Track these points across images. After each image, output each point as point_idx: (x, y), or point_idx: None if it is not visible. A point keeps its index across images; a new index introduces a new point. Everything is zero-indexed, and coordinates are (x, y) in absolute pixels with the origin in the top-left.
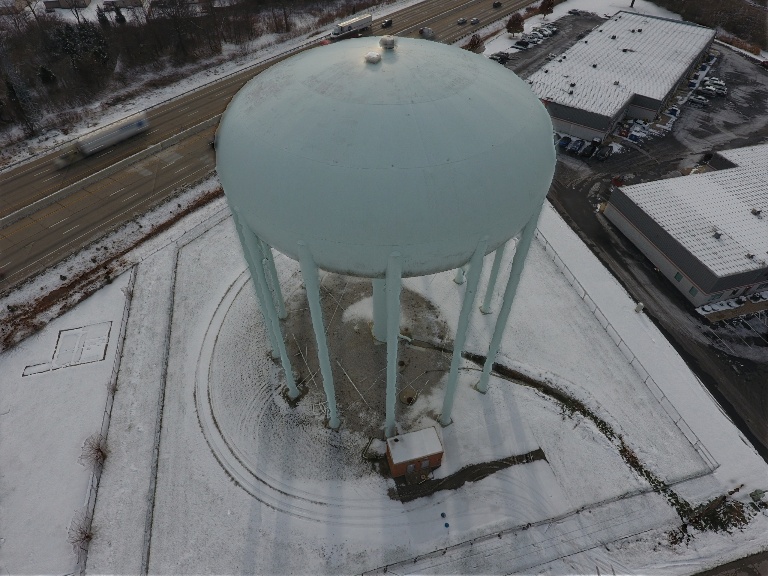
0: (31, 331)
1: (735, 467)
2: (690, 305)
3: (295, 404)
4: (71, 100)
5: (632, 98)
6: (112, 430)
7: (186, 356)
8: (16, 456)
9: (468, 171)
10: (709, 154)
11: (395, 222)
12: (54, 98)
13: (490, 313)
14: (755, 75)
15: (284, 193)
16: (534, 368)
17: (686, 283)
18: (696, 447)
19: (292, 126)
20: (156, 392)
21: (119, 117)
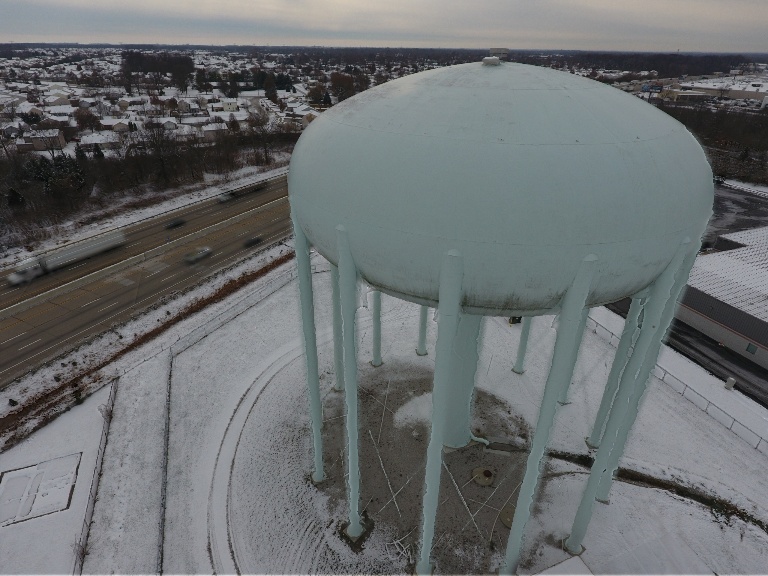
0: None
1: None
2: None
3: (360, 546)
4: (40, 220)
5: None
6: None
7: (192, 491)
8: None
9: (663, 151)
10: (705, 242)
11: (594, 209)
12: (20, 219)
13: (569, 403)
14: None
15: (425, 189)
16: (651, 464)
17: (764, 354)
18: None
19: (424, 113)
20: (149, 550)
21: (94, 233)
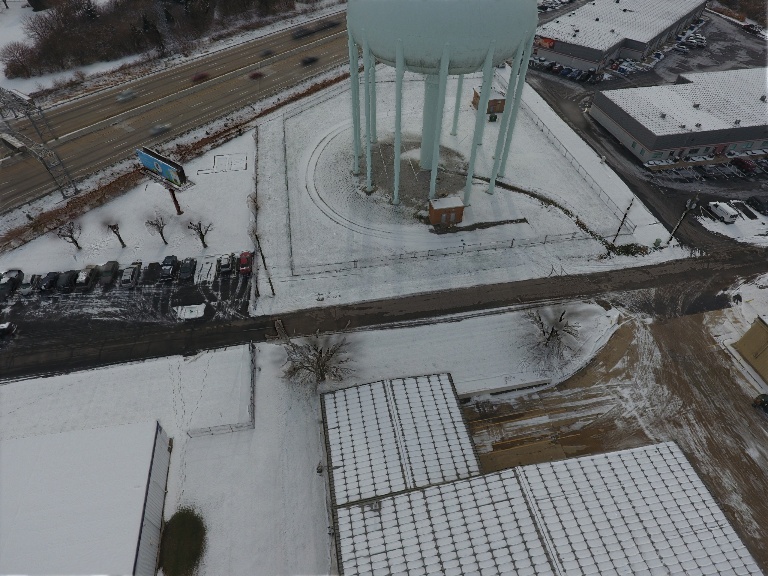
0: (196, 156)
1: (648, 232)
2: (640, 162)
3: (370, 194)
4: (186, 35)
5: (623, 41)
6: (259, 199)
7: (298, 170)
8: (204, 206)
9: (487, 1)
10: None
11: (449, 24)
12: (173, 33)
13: None
14: (735, 35)
15: (392, 13)
16: (526, 185)
17: (638, 147)
18: (625, 222)
19: None
20: (282, 185)
21: (224, 47)
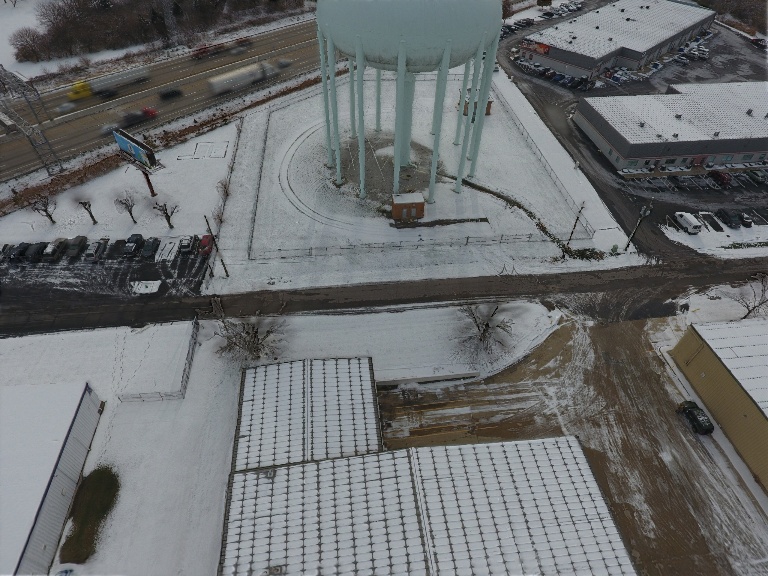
0: (179, 142)
1: (607, 238)
2: (615, 169)
3: (339, 186)
4: (193, 27)
5: (620, 50)
6: (231, 185)
7: (274, 161)
8: (178, 190)
9: (442, 1)
10: None
11: (404, 22)
12: (181, 25)
13: None
14: (741, 48)
15: (352, 9)
16: (494, 186)
17: (614, 155)
18: (586, 227)
19: None
20: (256, 173)
21: (227, 41)
